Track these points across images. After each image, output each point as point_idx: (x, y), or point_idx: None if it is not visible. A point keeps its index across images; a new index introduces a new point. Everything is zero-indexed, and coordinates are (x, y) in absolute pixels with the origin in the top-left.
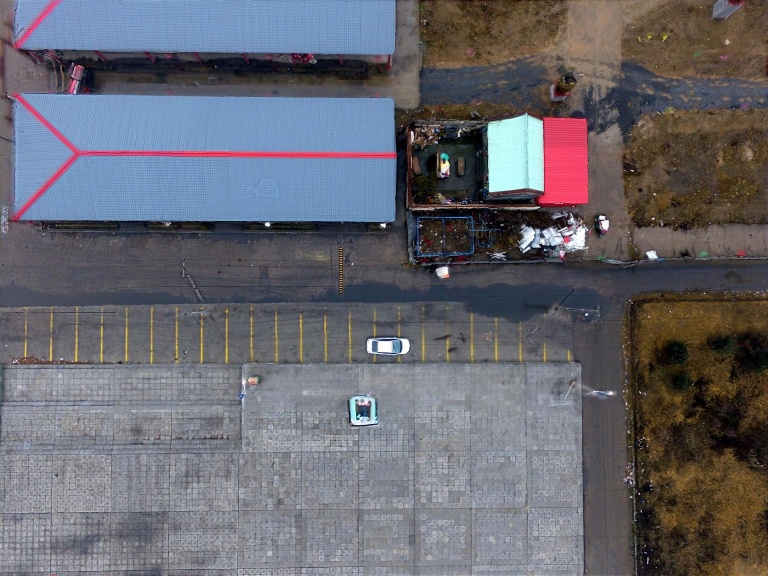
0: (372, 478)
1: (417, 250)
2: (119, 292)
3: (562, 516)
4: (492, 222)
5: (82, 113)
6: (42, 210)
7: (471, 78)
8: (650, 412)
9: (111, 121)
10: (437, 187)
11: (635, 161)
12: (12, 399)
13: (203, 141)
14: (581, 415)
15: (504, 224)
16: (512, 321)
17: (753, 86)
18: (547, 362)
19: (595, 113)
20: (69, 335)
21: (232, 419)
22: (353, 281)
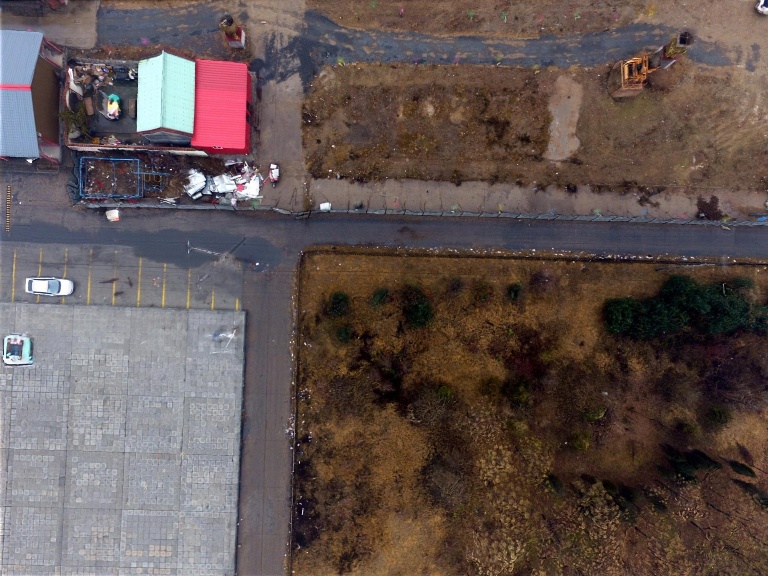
0: (24, 418)
1: (79, 190)
2: None
3: (217, 464)
4: (165, 167)
5: None
6: None
7: (150, 20)
8: (314, 364)
9: None
10: (110, 129)
11: (314, 112)
12: None
13: None
14: (242, 364)
15: (172, 168)
16: (181, 267)
17: (437, 41)
18: (212, 310)
19: (276, 62)
20: None
21: None
22: (20, 220)
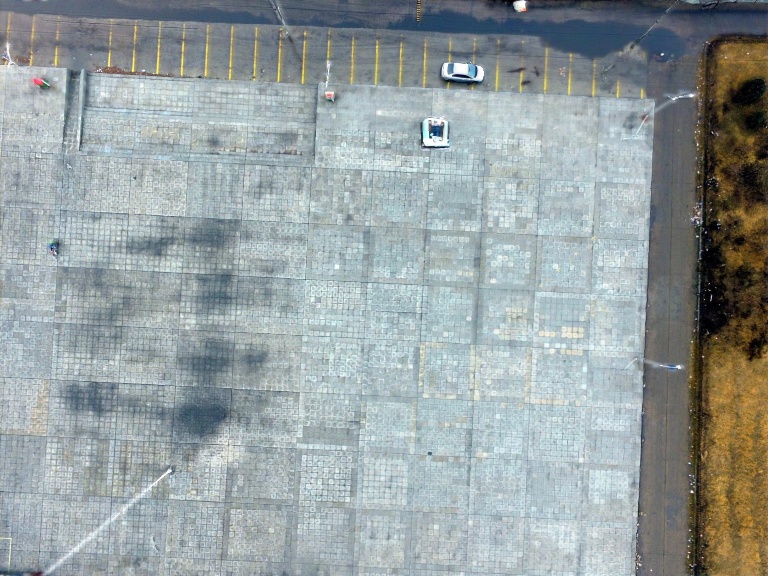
0: (441, 200)
1: None
2: (201, 9)
3: (627, 248)
4: None
5: None
6: None
7: None
8: (721, 152)
9: None
10: None
11: None
12: (95, 105)
13: None
14: (652, 150)
15: None
16: (587, 57)
17: None
18: (620, 98)
19: None
20: (151, 48)
21: (306, 136)
22: (430, 10)
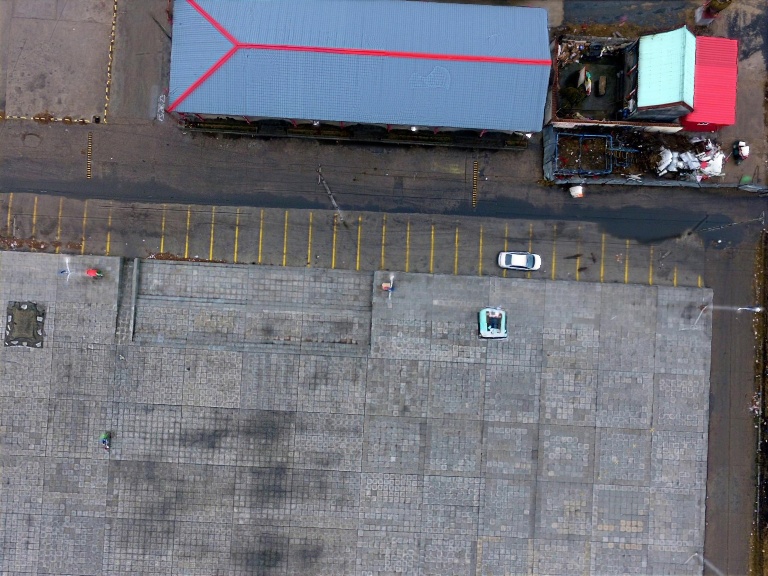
0: (498, 391)
1: (555, 166)
2: (255, 194)
3: (687, 440)
4: (629, 144)
5: (239, 8)
6: (195, 102)
7: None
8: None
9: (268, 16)
10: None
11: None
12: (148, 292)
13: (359, 40)
14: (711, 341)
15: (643, 145)
16: (644, 244)
17: None
18: (678, 286)
19: (738, 39)
20: (205, 233)
21: (362, 325)
22: (486, 196)
